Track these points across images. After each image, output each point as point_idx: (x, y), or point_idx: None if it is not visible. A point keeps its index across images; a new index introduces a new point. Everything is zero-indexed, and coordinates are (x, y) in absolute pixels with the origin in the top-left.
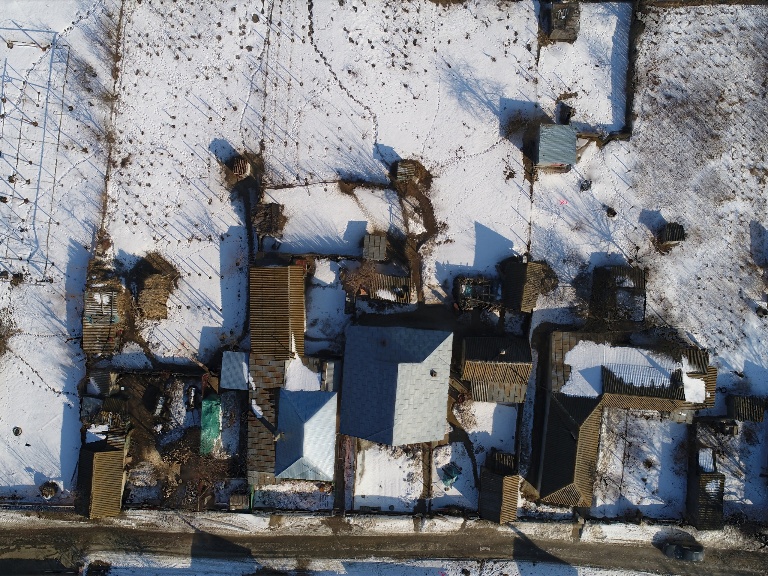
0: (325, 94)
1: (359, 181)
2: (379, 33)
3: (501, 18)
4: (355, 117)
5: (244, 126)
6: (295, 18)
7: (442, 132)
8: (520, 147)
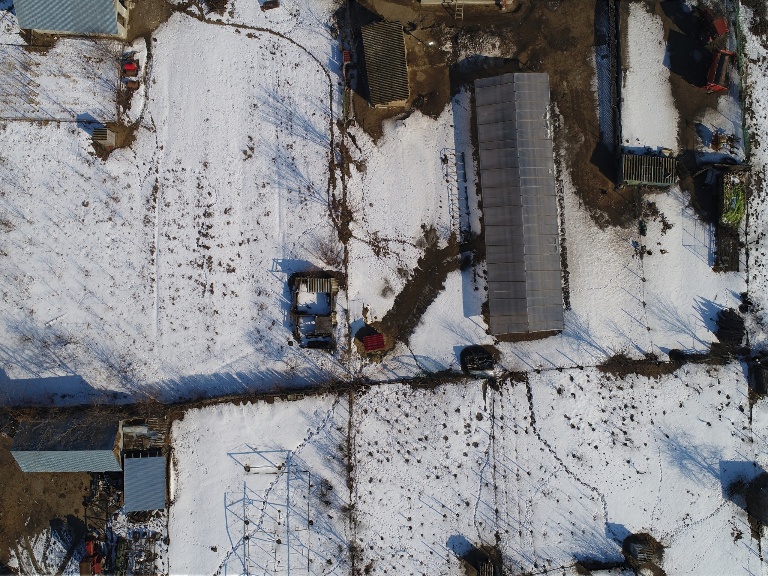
0: (553, 481)
1: (596, 563)
2: (598, 415)
3: (712, 384)
4: (584, 500)
5: (478, 520)
6: (516, 410)
7: (668, 502)
8: (744, 507)
